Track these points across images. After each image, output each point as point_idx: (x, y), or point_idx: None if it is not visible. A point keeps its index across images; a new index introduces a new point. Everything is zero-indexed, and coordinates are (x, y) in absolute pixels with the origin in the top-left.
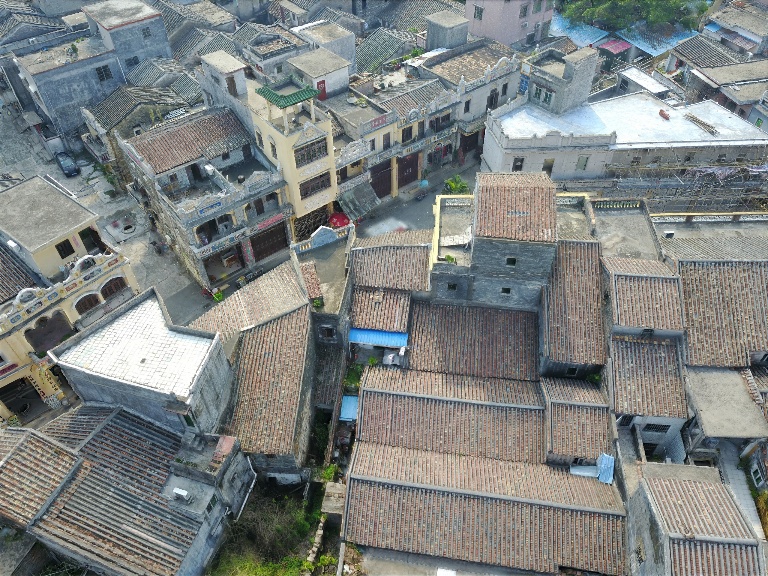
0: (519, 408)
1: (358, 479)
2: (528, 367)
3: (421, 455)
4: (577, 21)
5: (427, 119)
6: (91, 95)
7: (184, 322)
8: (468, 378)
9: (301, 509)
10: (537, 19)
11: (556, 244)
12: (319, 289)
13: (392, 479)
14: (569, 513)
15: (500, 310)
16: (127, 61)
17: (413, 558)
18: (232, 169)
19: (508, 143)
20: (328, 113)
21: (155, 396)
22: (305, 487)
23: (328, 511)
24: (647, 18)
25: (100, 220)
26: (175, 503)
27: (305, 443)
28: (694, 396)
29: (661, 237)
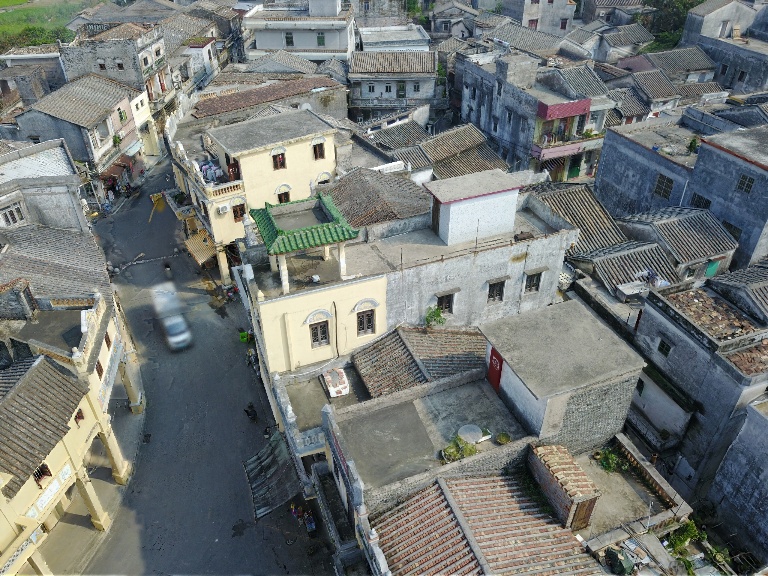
0: None
1: None
2: None
3: None
4: None
5: None
6: (637, 197)
7: (229, 313)
8: None
9: None
10: None
11: None
12: None
13: None
14: None
15: None
16: (697, 197)
17: None
18: None
19: None
20: (259, 290)
21: None
22: None
23: None
24: None
25: None
26: None
27: None
28: None
29: None
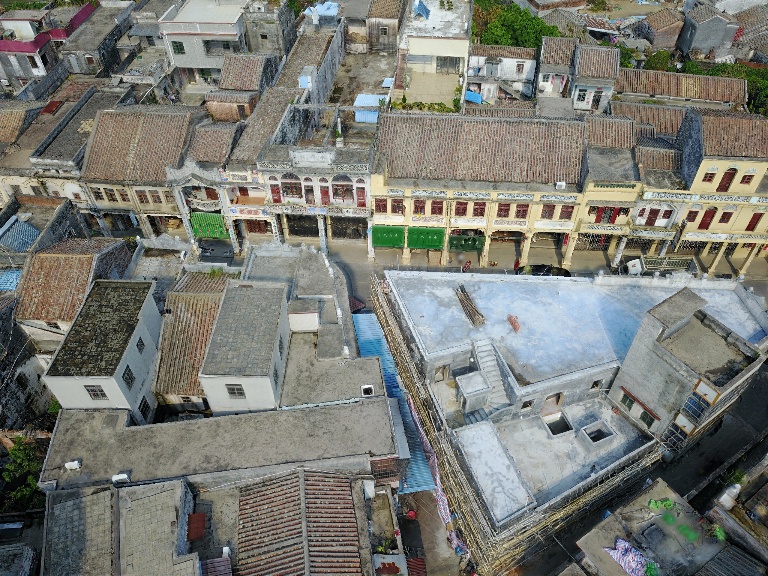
0: None
1: None
2: None
3: None
4: None
5: None
6: None
7: None
8: None
9: None
10: None
11: None
12: None
13: None
14: None
15: None
16: None
17: None
18: None
19: None
20: None
21: None
22: None
23: None
24: None
25: None
26: None
27: None
28: None
29: None
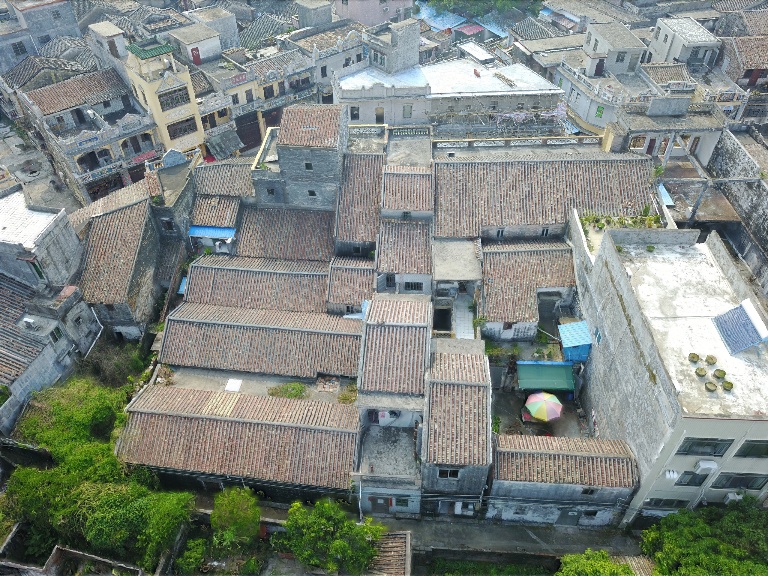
0: (310, 275)
1: (174, 320)
2: (328, 251)
3: (231, 309)
4: (442, 10)
5: (286, 80)
6: (8, 67)
7: None
8: (281, 260)
9: (136, 350)
10: (398, 5)
11: (336, 149)
12: (159, 190)
13: (201, 320)
14: (329, 336)
15: (311, 211)
16: (40, 39)
17: (212, 374)
18: (114, 116)
19: (343, 94)
20: (186, 66)
21: (10, 249)
22: (141, 335)
23: (155, 349)
24: (495, 5)
25: (10, 167)
26: (25, 330)
27: (147, 308)
28: (434, 256)
29: (445, 157)
